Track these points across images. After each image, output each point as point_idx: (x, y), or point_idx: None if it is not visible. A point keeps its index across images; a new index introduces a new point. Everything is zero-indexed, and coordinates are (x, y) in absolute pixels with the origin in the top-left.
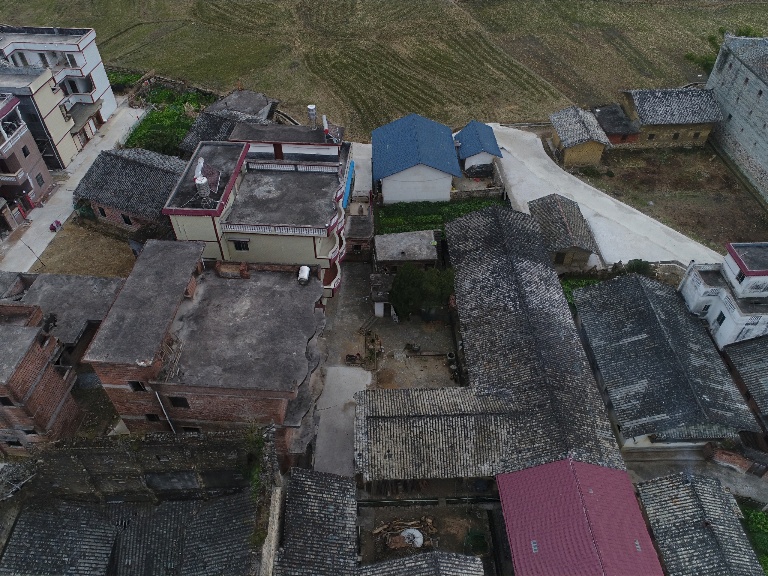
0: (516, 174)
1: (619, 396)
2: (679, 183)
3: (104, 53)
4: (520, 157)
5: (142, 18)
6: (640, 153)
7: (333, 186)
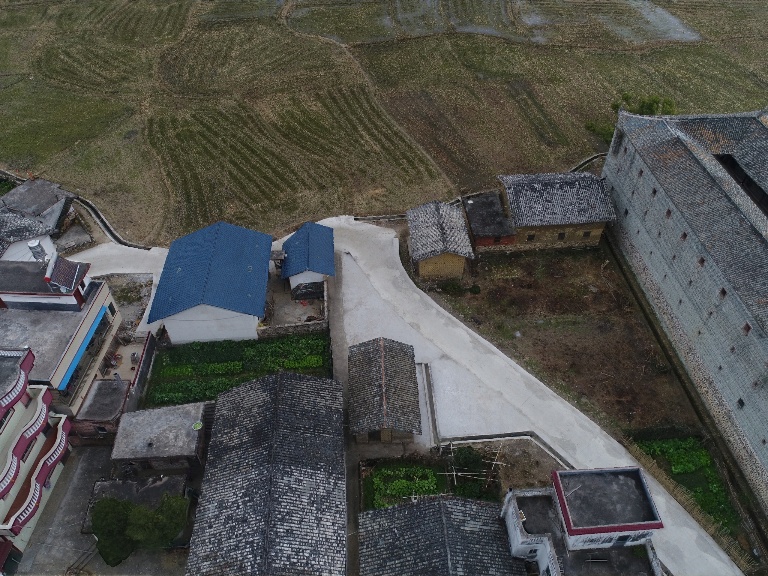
0: (356, 293)
1: None
2: (558, 303)
3: None
4: (367, 267)
5: None
6: (519, 257)
7: (10, 383)
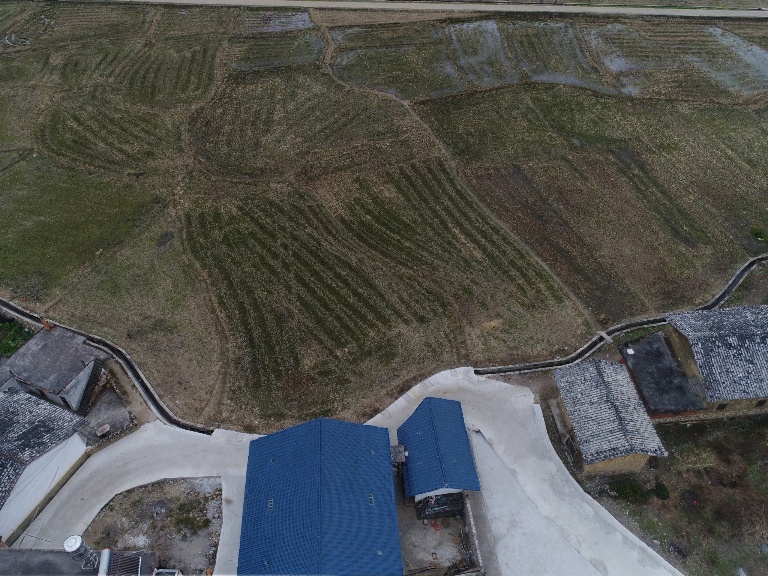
0: (503, 505)
1: None
2: None
3: None
4: (509, 457)
5: None
6: (703, 430)
7: None
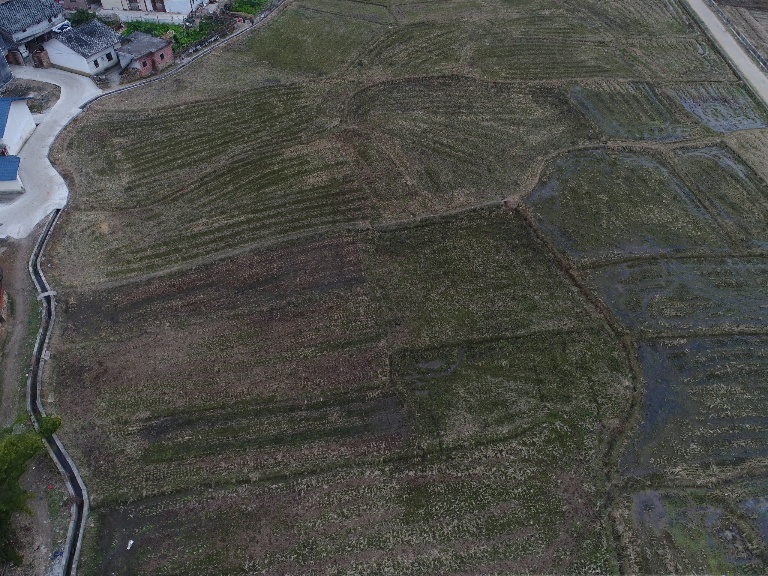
0: None
1: None
2: None
3: (318, 2)
4: None
5: (400, 6)
6: None
7: None
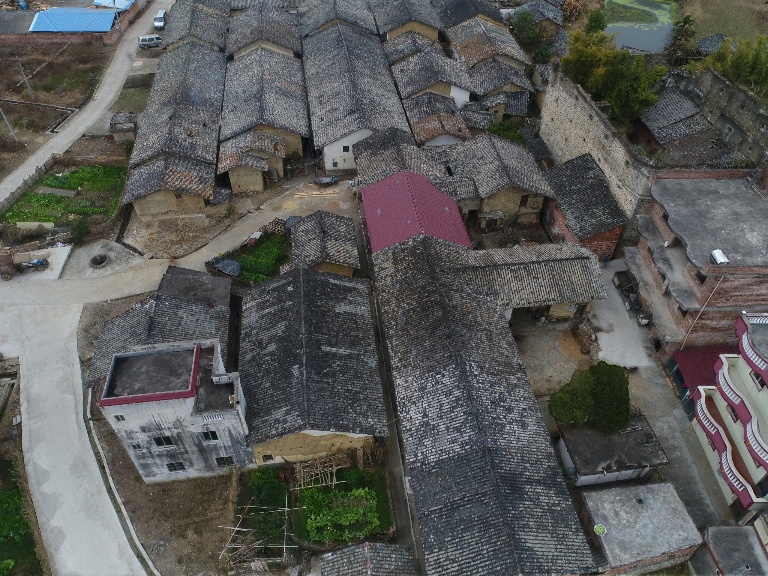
0: None
1: (363, 307)
2: None
3: None
4: None
5: None
6: None
7: None
